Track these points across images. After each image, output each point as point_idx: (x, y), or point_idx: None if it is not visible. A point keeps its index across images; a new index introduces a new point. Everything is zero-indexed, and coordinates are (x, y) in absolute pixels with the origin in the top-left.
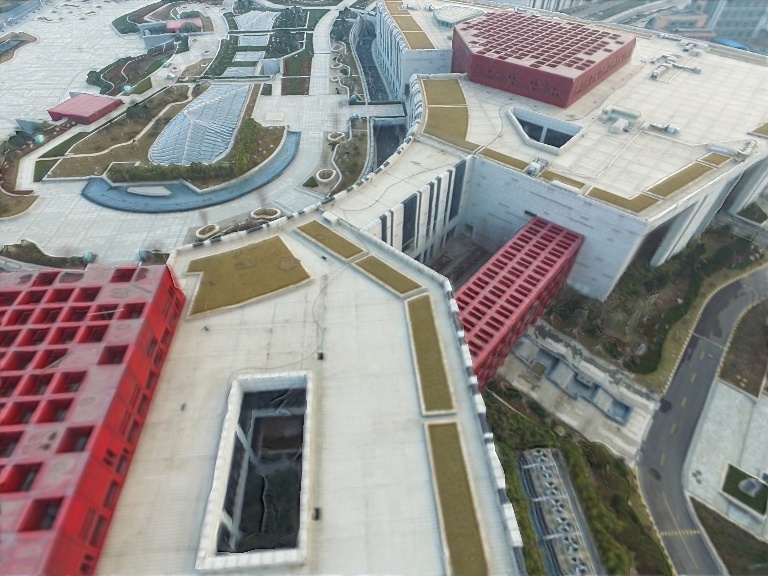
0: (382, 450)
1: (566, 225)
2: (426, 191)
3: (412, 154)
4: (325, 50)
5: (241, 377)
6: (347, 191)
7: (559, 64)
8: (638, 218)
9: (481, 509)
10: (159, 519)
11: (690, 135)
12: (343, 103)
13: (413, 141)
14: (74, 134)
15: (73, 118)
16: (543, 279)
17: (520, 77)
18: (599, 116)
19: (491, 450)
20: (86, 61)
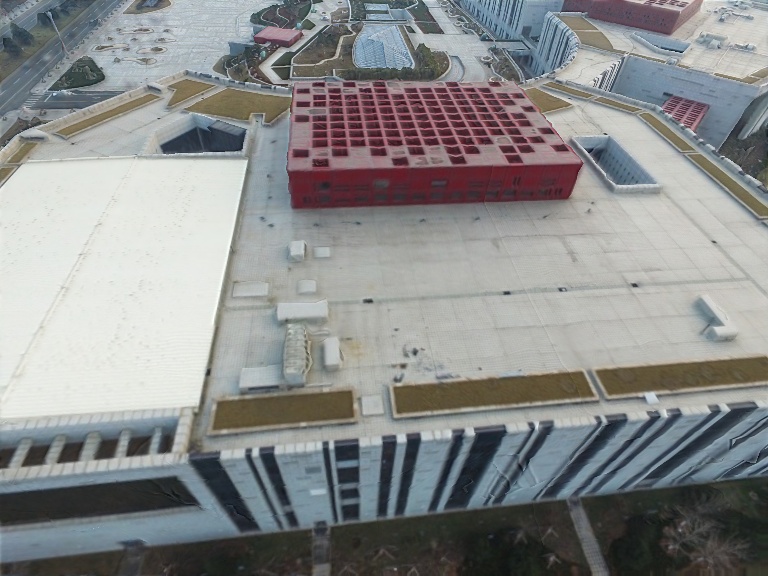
0: (668, 163)
1: (696, 99)
2: (610, 71)
3: (583, 55)
4: (435, 5)
5: (575, 136)
6: (560, 69)
7: (664, 3)
8: (753, 85)
9: (733, 178)
10: (577, 179)
11: (763, 51)
12: (476, 40)
13: (578, 48)
14: (283, 53)
15: (276, 42)
16: (695, 122)
17: (635, 12)
18: (697, 39)
19: (728, 160)
20: (235, 8)
